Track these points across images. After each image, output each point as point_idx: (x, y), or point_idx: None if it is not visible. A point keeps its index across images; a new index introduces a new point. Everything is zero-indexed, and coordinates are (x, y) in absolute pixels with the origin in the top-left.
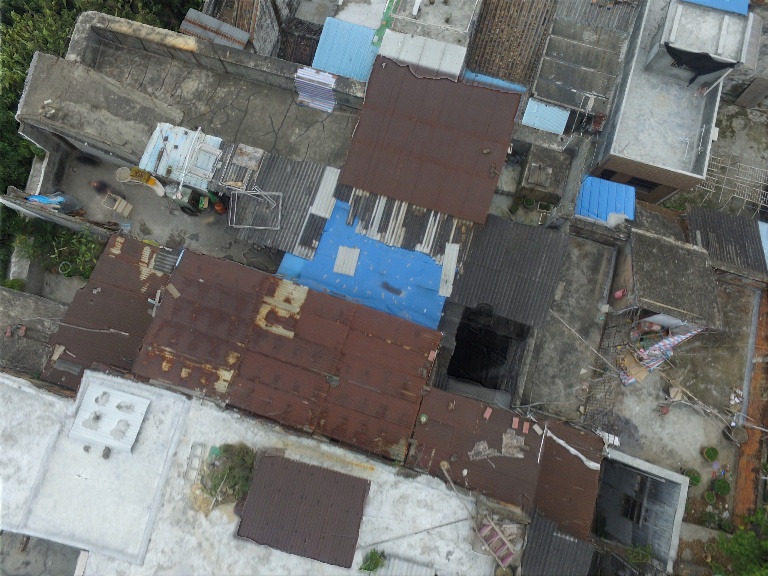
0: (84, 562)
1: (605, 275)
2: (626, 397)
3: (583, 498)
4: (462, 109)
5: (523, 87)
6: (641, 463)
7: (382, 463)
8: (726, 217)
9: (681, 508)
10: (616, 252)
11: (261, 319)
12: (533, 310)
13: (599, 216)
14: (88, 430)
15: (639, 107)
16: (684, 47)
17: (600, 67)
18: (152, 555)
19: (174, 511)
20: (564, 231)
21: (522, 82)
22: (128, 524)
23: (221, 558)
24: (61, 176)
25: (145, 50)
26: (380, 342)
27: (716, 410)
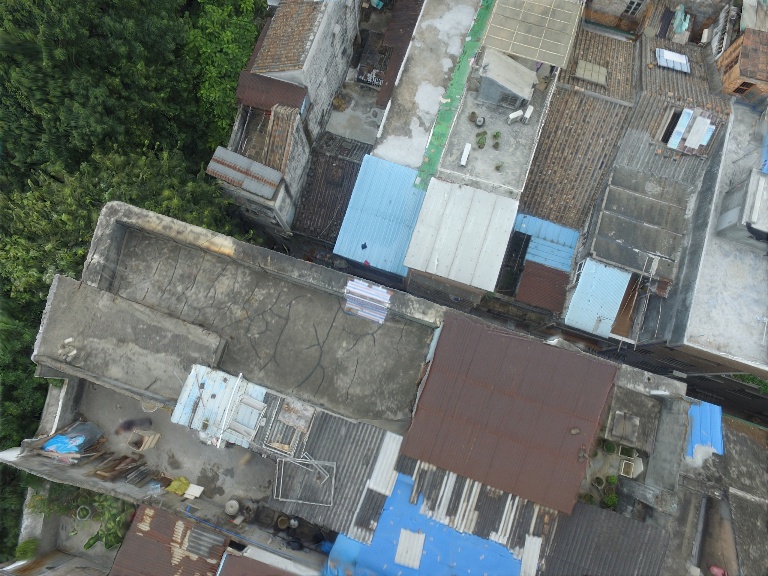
0: None
1: (693, 527)
2: None
3: None
4: (547, 379)
5: (576, 231)
6: None
7: None
8: None
9: None
10: (705, 500)
11: None
12: None
13: (684, 451)
14: None
15: (710, 278)
16: (767, 228)
17: (664, 224)
18: None
19: None
20: (664, 526)
21: (575, 226)
22: None
23: None
24: (80, 396)
25: (175, 242)
26: None
27: None
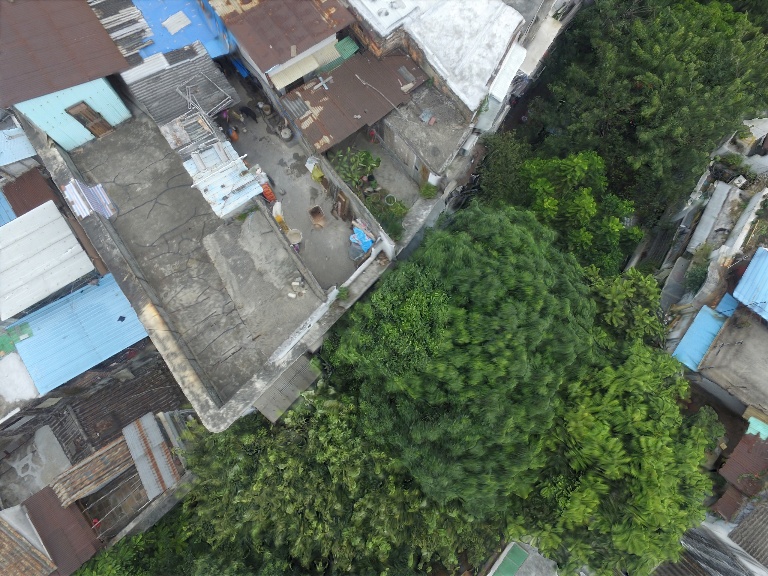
0: None
1: None
2: None
3: None
4: None
5: None
6: None
7: None
8: None
9: None
10: None
11: (254, 3)
12: None
13: None
14: (403, 1)
15: None
16: None
17: None
18: None
19: None
20: None
21: None
22: None
23: None
24: None
25: (197, 362)
26: None
27: None
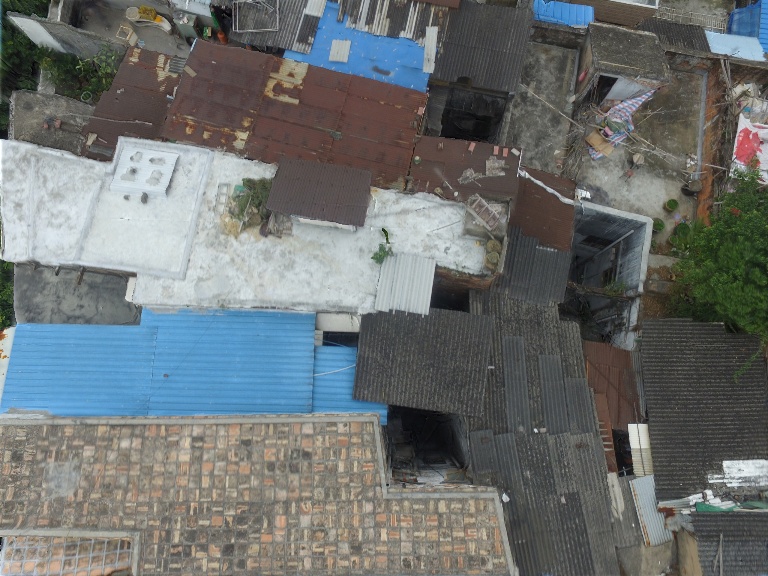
0: (133, 286)
1: (570, 73)
2: (596, 170)
3: (561, 227)
4: None
5: None
6: (611, 210)
7: (384, 189)
8: (675, 24)
9: (647, 241)
10: (579, 53)
11: (269, 91)
12: (506, 78)
13: None
14: (126, 182)
15: None
16: None
17: None
18: (192, 271)
19: (208, 236)
20: (528, 8)
21: None
22: (169, 250)
23: (252, 268)
24: (75, 23)
25: None
26: (375, 104)
27: (675, 173)
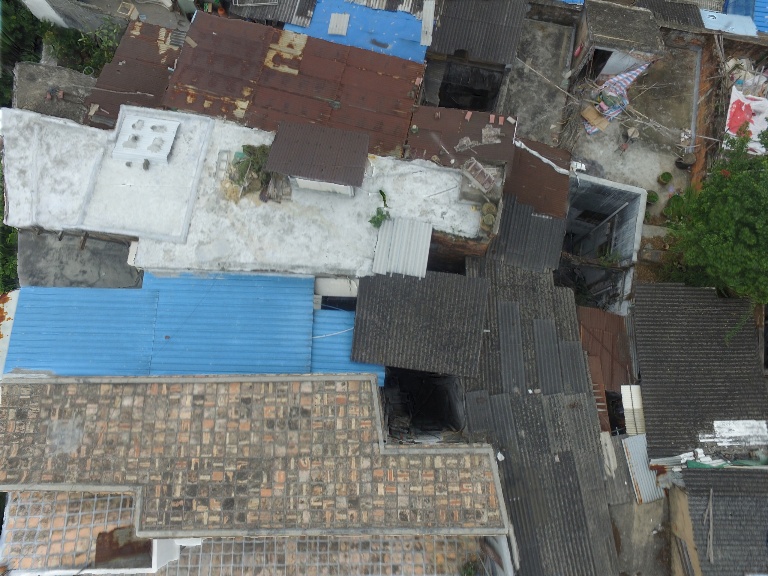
0: (135, 250)
1: (567, 50)
2: (591, 144)
3: (556, 197)
4: None
5: None
6: (605, 181)
7: None
8: (670, 3)
9: (641, 212)
10: (575, 30)
11: (269, 61)
12: (503, 50)
13: None
14: (128, 149)
15: None
16: None
17: None
18: (193, 235)
19: (208, 202)
20: None
21: None
22: (170, 215)
23: (252, 232)
24: None
25: None
26: (373, 74)
27: (669, 147)
